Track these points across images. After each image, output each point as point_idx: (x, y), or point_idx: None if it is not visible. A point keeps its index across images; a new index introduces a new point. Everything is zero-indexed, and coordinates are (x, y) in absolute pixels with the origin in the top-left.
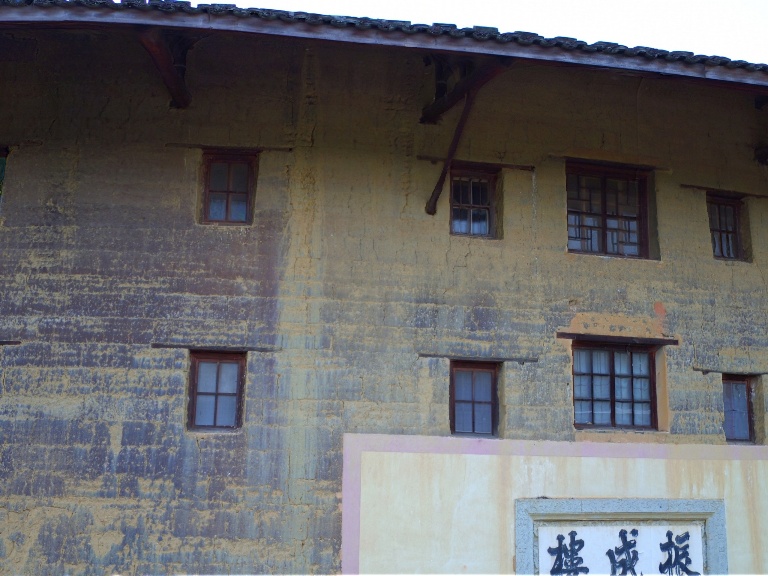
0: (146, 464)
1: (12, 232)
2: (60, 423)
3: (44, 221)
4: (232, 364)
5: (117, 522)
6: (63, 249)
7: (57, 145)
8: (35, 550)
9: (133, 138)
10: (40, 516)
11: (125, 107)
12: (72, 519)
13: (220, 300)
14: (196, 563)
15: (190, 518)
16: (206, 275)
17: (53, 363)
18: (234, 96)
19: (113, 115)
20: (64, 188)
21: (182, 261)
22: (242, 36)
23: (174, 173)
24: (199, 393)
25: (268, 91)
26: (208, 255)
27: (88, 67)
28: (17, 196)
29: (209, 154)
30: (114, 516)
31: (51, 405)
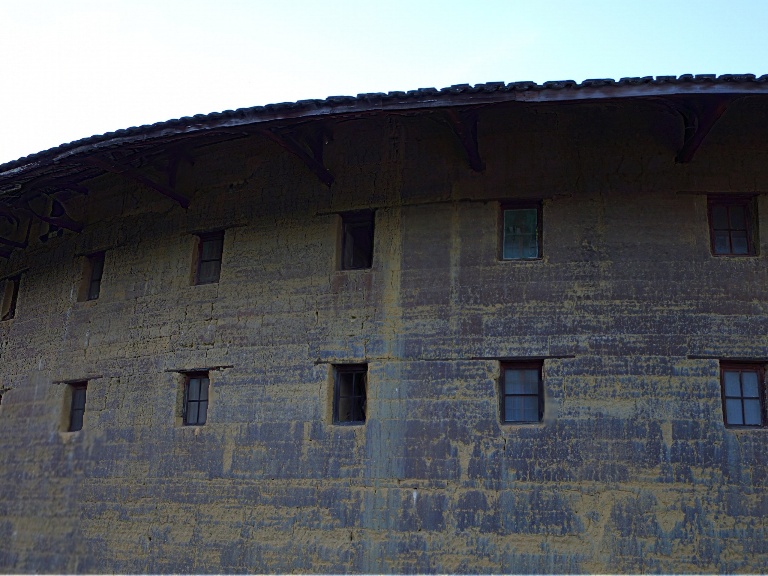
0: (696, 455)
1: (556, 268)
2: (618, 421)
3: (582, 258)
4: (751, 373)
5: (677, 503)
6: (602, 280)
7: (585, 197)
8: (609, 526)
9: (648, 188)
10: (610, 498)
11: (638, 164)
12: (638, 500)
13: (741, 319)
14: (750, 538)
15: (740, 500)
16: (726, 298)
17: (605, 373)
18: (729, 151)
19: (628, 171)
20: (596, 231)
21: (704, 287)
22: (737, 101)
23: (687, 215)
24: (727, 397)
25: (757, 145)
26: (726, 282)
27: (602, 133)
28: (556, 239)
29: (710, 199)
30: (674, 498)
31: (608, 407)
